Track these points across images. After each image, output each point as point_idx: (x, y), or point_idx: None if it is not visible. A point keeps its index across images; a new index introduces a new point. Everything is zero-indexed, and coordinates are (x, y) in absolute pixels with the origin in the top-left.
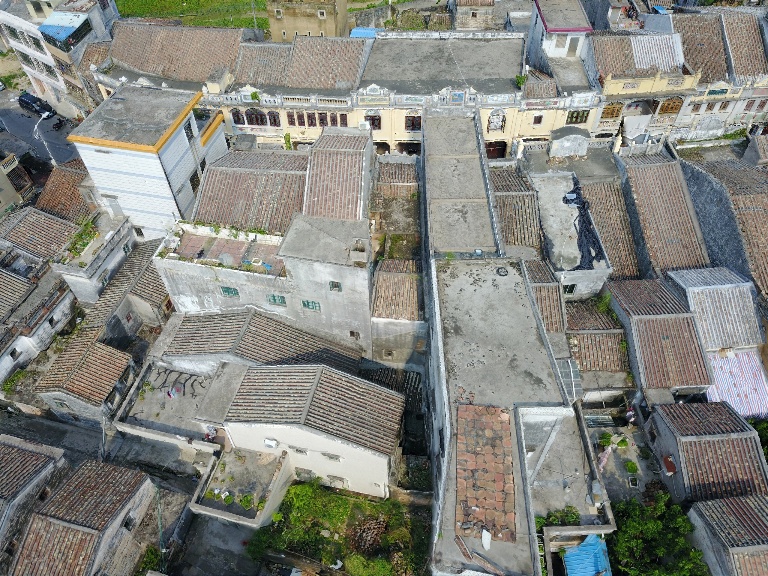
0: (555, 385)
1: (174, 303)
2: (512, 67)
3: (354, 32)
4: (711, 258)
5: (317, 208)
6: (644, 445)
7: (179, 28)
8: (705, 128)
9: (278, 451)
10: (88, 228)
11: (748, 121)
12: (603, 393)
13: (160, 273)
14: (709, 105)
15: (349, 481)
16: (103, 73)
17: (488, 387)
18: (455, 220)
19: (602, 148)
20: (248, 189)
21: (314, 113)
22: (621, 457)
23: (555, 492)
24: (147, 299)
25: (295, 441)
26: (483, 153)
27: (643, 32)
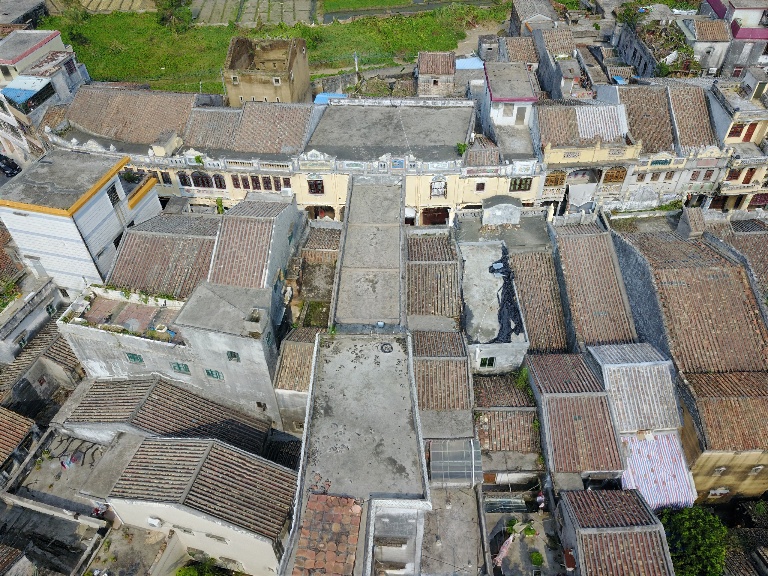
0: (418, 474)
1: (84, 368)
2: (458, 135)
3: (318, 97)
4: (638, 333)
5: (222, 275)
6: (554, 534)
7: (136, 93)
8: (639, 199)
9: (166, 530)
10: (10, 288)
11: (683, 193)
12: (515, 475)
13: (66, 337)
14: (654, 175)
15: (243, 564)
16: (58, 135)
17: (347, 475)
18: (364, 290)
19: (537, 217)
20: (164, 254)
21: (258, 177)
22: (528, 547)
23: None
24: (60, 362)
25: (177, 521)
26: (401, 222)
27: (592, 102)
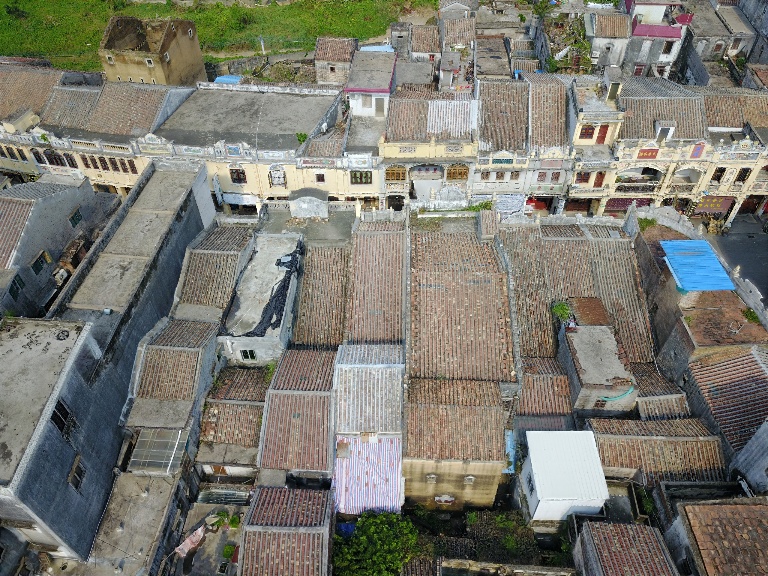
0: None
1: None
2: (311, 124)
3: (218, 80)
4: None
5: None
6: None
7: (8, 69)
8: (446, 198)
9: None
10: None
11: None
12: (240, 468)
13: None
14: (499, 174)
15: None
16: None
17: None
18: (111, 276)
19: (349, 211)
20: None
21: (104, 157)
22: (227, 539)
23: (106, 572)
24: None
25: None
26: (175, 210)
27: (459, 96)
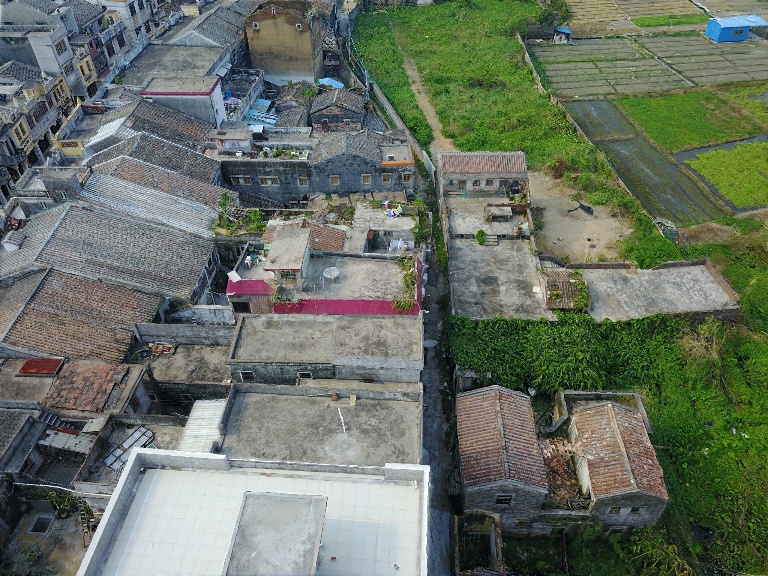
0: None
1: None
2: None
3: (325, 79)
4: None
5: None
6: None
7: None
8: None
9: None
10: None
11: None
12: None
13: None
14: None
15: None
16: None
17: None
18: None
19: None
20: None
21: None
22: None
23: None
24: None
25: None
26: None
27: None
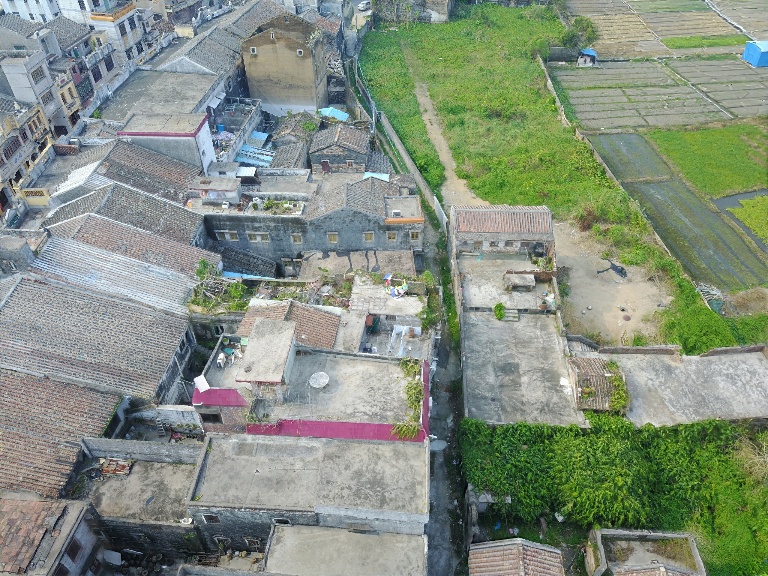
0: None
1: None
2: None
3: None
4: None
5: None
6: None
7: None
8: None
9: None
10: None
11: None
12: None
13: None
14: None
15: None
16: None
17: None
18: None
19: None
20: None
21: None
22: None
23: None
24: None
25: None
26: None
27: None
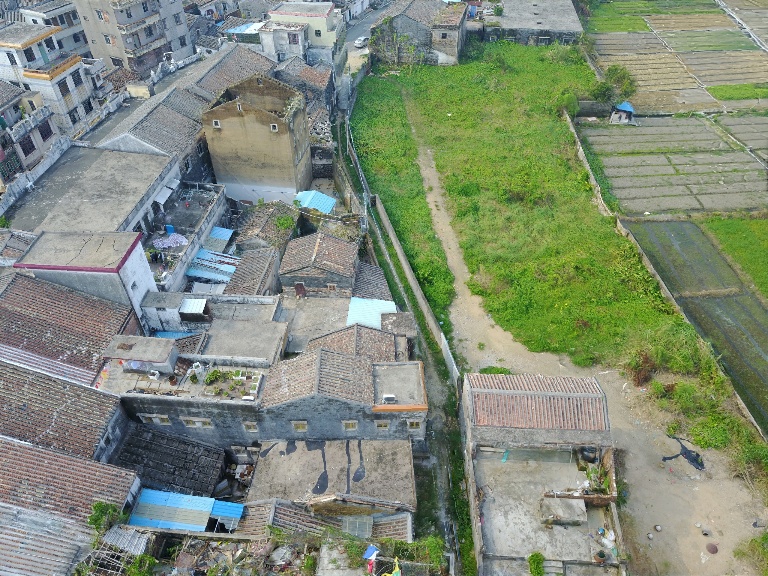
0: None
1: None
2: None
3: (311, 192)
4: None
5: None
6: None
7: None
8: None
9: None
10: None
11: None
12: None
13: None
14: None
15: None
16: None
17: None
18: None
19: None
20: None
21: None
22: None
23: None
24: None
25: None
26: None
27: (33, 359)
